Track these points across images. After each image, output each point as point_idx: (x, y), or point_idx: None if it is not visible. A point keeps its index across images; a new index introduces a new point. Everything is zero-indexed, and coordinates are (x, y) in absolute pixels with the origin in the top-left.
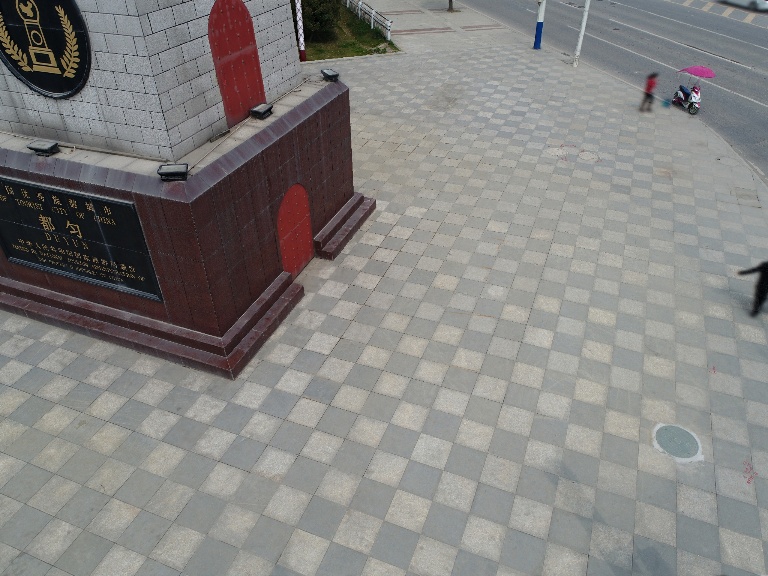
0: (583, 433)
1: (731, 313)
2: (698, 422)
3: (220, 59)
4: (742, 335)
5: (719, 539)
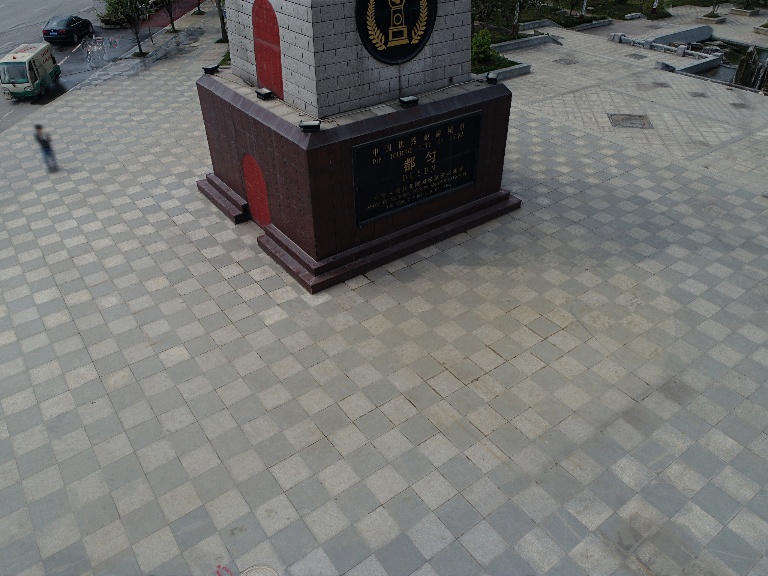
0: None
1: None
2: None
3: None
4: None
5: None
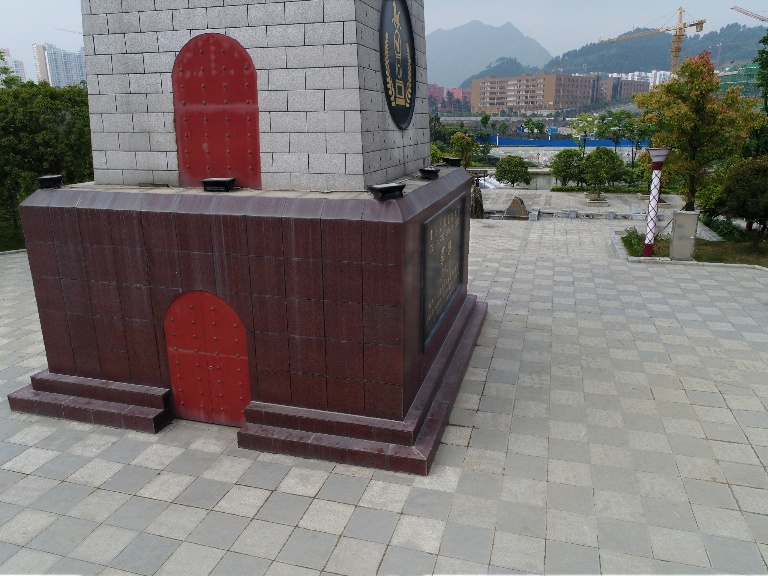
0: None
1: None
2: None
3: (187, 105)
4: None
5: None
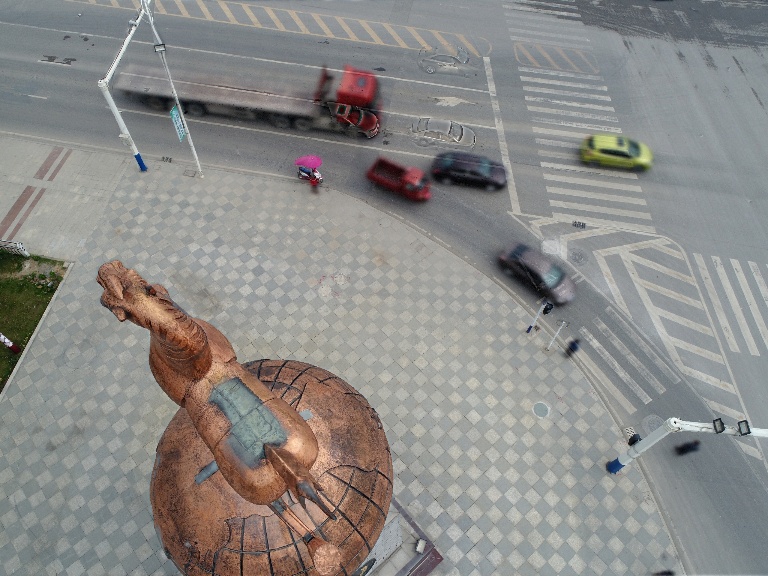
0: (526, 437)
1: (493, 335)
2: (536, 396)
3: None
4: (505, 343)
5: (576, 429)
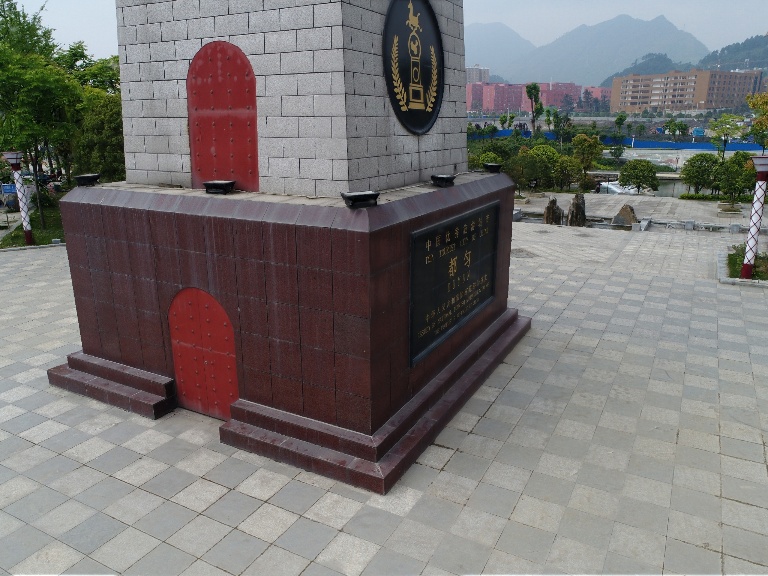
0: None
1: None
2: None
3: (199, 110)
4: None
5: None
